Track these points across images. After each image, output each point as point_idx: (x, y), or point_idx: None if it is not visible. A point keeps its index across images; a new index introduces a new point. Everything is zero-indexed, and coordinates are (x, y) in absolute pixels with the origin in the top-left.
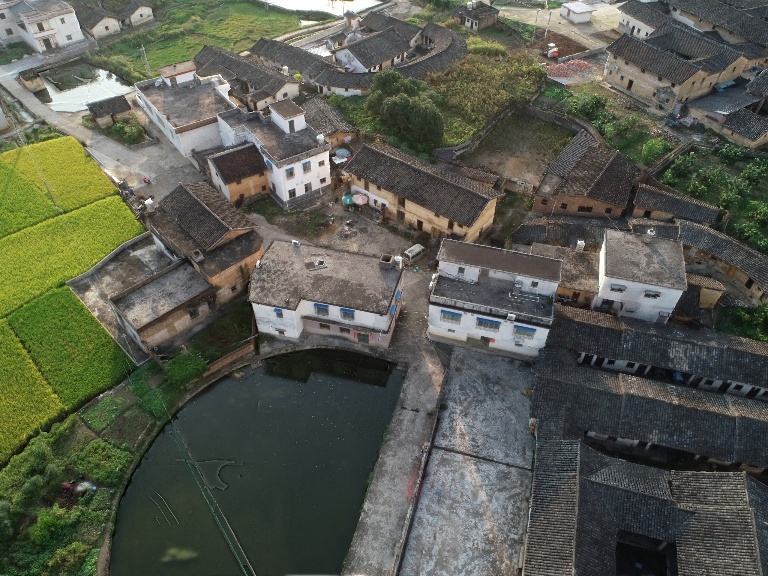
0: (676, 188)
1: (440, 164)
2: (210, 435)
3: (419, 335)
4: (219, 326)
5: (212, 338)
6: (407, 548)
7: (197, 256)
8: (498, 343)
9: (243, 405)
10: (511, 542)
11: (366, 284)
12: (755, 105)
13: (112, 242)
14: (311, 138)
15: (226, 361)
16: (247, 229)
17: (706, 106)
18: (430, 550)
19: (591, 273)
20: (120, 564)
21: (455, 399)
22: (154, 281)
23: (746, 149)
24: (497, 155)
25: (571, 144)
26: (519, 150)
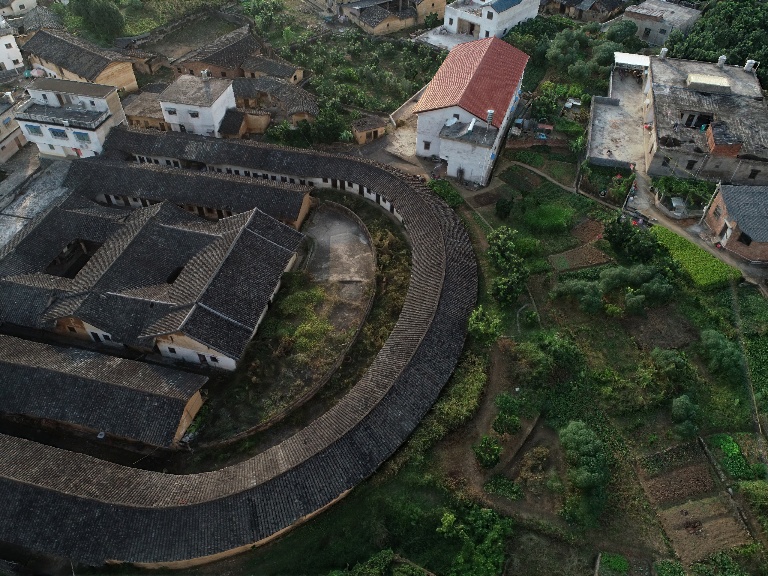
0: (295, 61)
1: (113, 48)
2: None
3: (34, 155)
4: None
5: None
6: None
7: None
8: (85, 155)
9: None
10: None
11: None
12: (397, 5)
13: None
14: None
15: None
16: None
17: (352, 5)
18: None
19: None
20: None
21: (34, 189)
22: None
23: (369, 35)
24: (175, 45)
25: (229, 33)
26: (196, 42)
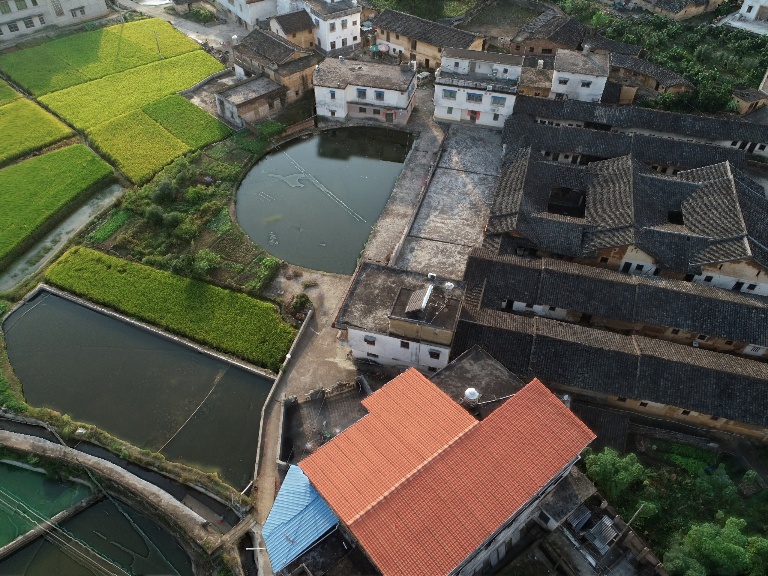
0: None
1: None
2: (290, 163)
3: (427, 119)
4: (288, 114)
5: (285, 119)
6: (422, 206)
7: (274, 65)
8: (482, 120)
9: (310, 151)
10: (487, 204)
11: (392, 78)
12: None
13: (204, 73)
14: (347, 6)
15: (296, 128)
16: (306, 53)
17: None
18: (436, 207)
19: (547, 79)
20: (242, 215)
21: (452, 147)
22: (242, 85)
23: (670, 20)
24: (484, 27)
25: (540, 17)
26: (501, 24)
